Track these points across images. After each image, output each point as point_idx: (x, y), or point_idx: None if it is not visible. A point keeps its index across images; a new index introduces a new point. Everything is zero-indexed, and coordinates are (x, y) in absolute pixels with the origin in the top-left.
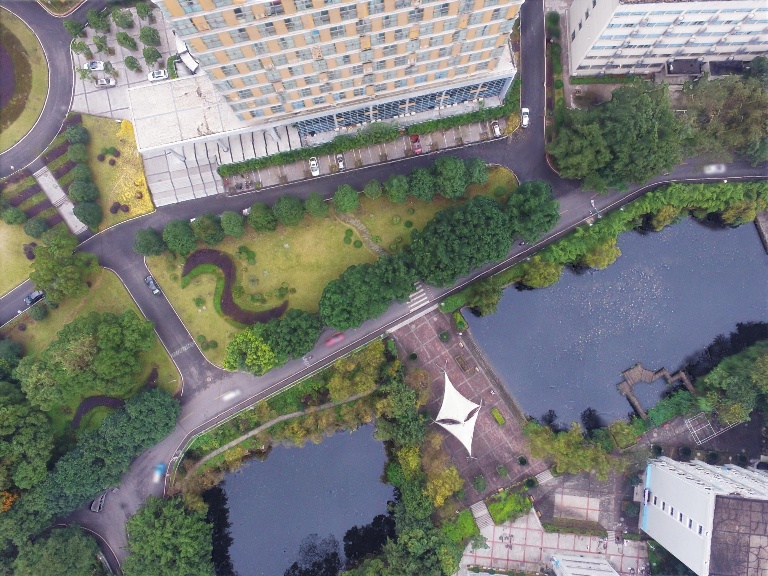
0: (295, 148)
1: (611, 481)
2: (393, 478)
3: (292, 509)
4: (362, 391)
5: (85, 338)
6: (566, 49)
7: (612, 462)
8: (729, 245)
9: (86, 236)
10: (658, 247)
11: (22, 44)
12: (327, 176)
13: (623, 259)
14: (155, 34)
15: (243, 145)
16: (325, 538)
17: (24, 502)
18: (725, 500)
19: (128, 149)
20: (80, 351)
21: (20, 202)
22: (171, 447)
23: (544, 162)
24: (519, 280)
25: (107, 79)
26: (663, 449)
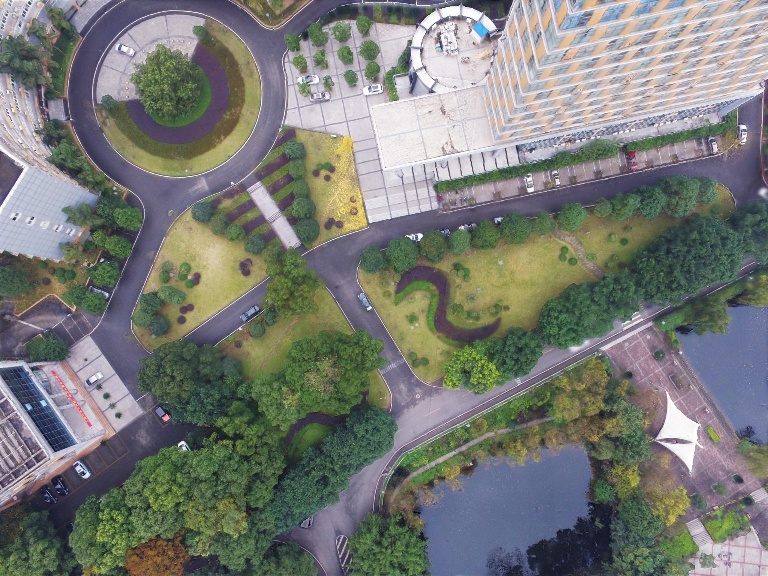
0: (514, 165)
1: None
2: (601, 495)
3: (498, 525)
4: (591, 411)
5: (331, 359)
6: None
7: None
8: None
9: None
10: None
11: (234, 57)
12: (541, 193)
13: None
14: (376, 48)
15: (461, 161)
16: (512, 552)
17: (257, 521)
18: None
19: (343, 164)
20: (331, 372)
21: (236, 218)
22: (380, 464)
23: (760, 179)
24: (731, 298)
25: (322, 93)
26: None
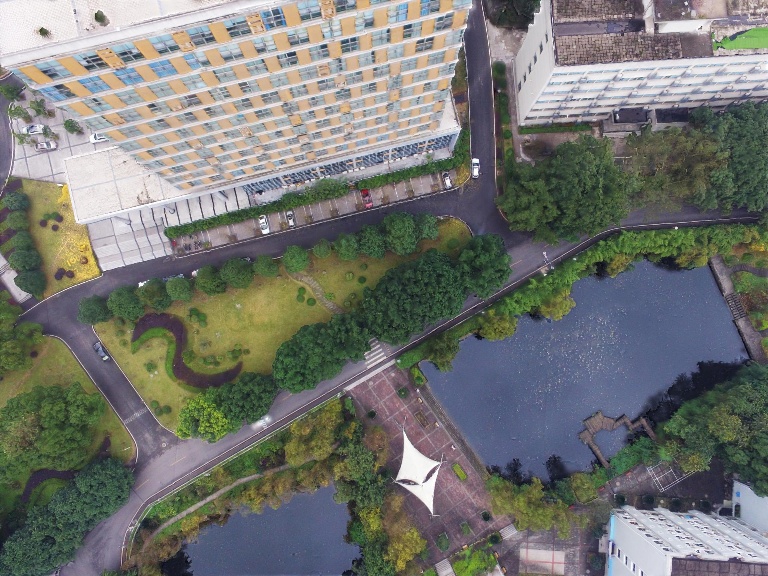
0: (243, 207)
1: (575, 533)
2: (356, 538)
3: (254, 574)
4: (318, 456)
5: (26, 418)
6: (514, 99)
7: (573, 519)
8: (684, 288)
9: (31, 304)
10: (614, 293)
11: None
12: (278, 234)
13: (580, 306)
14: None
15: (190, 206)
16: None
17: None
18: (682, 562)
19: (71, 213)
20: (21, 433)
21: None
22: (127, 516)
23: (497, 212)
24: (476, 331)
25: (47, 142)
26: (626, 498)
